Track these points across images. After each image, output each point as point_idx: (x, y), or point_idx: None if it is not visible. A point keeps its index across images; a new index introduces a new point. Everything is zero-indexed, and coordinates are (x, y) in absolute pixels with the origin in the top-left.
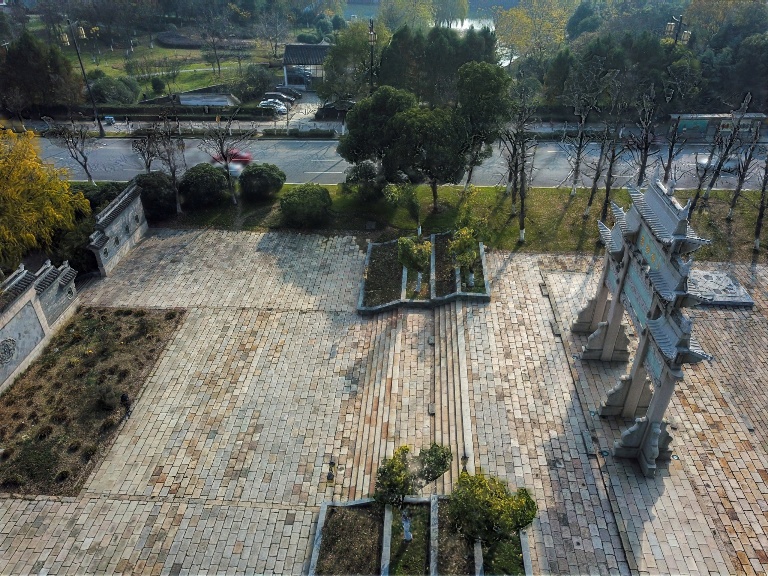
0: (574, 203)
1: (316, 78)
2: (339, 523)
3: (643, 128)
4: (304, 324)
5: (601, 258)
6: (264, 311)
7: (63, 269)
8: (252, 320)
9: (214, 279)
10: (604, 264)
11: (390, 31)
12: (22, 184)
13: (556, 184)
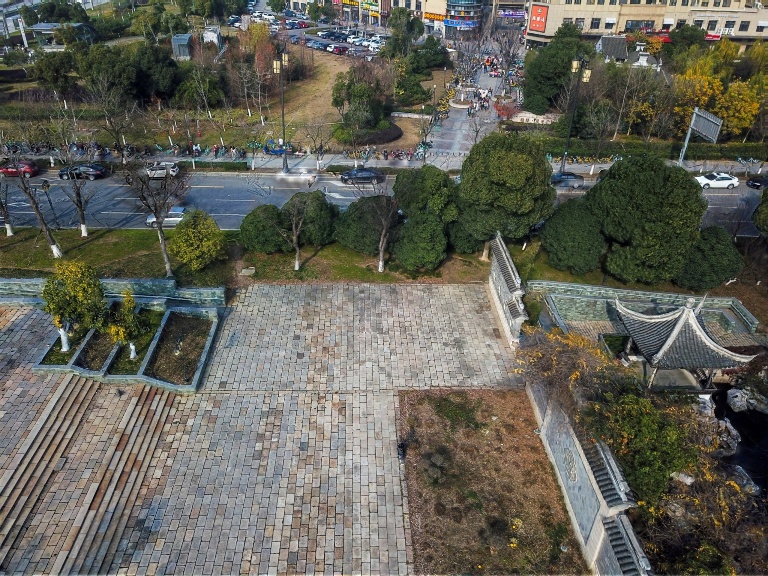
0: None
1: None
2: None
3: None
4: None
5: None
6: None
7: None
8: None
9: None
10: None
11: None
12: None
13: None
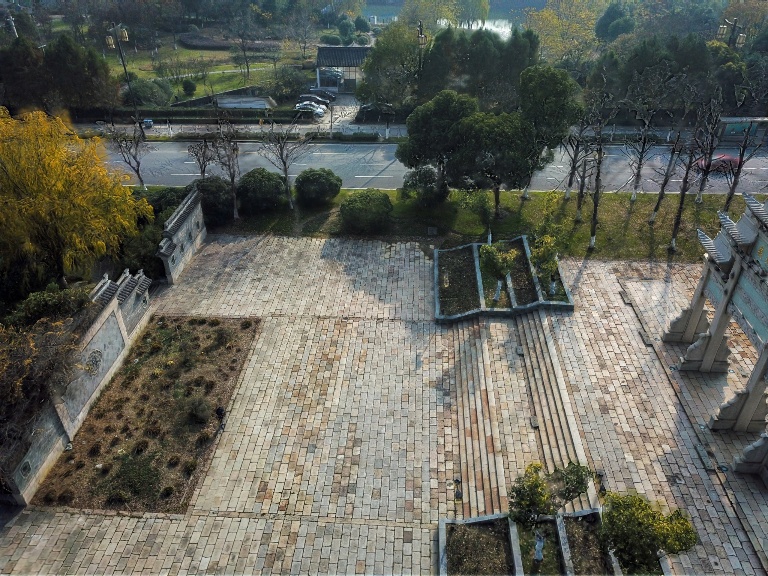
0: (637, 208)
1: (349, 80)
2: (462, 542)
3: (689, 131)
4: (383, 333)
5: (676, 265)
6: (340, 320)
7: (139, 278)
8: (330, 329)
9: (283, 287)
10: (703, 274)
11: (430, 33)
12: (91, 191)
13: (613, 189)
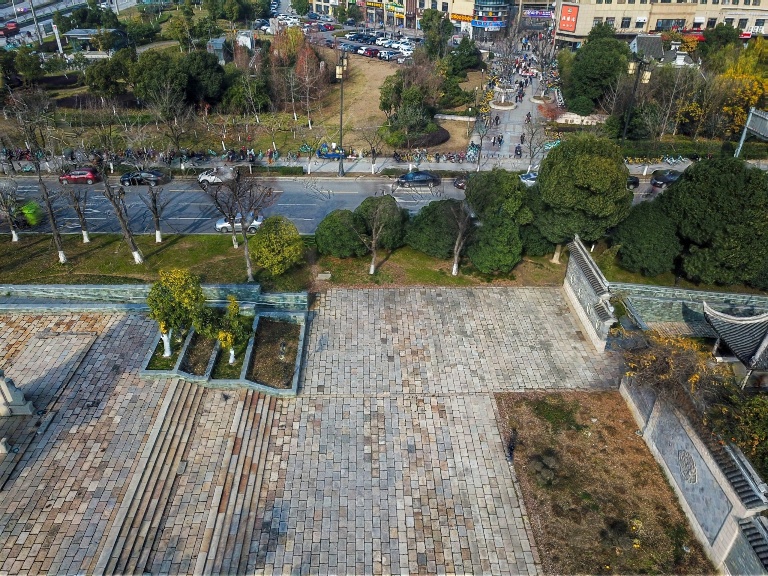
0: None
1: None
2: None
3: None
4: None
5: None
6: None
7: None
8: None
9: None
10: None
11: None
12: None
13: None
